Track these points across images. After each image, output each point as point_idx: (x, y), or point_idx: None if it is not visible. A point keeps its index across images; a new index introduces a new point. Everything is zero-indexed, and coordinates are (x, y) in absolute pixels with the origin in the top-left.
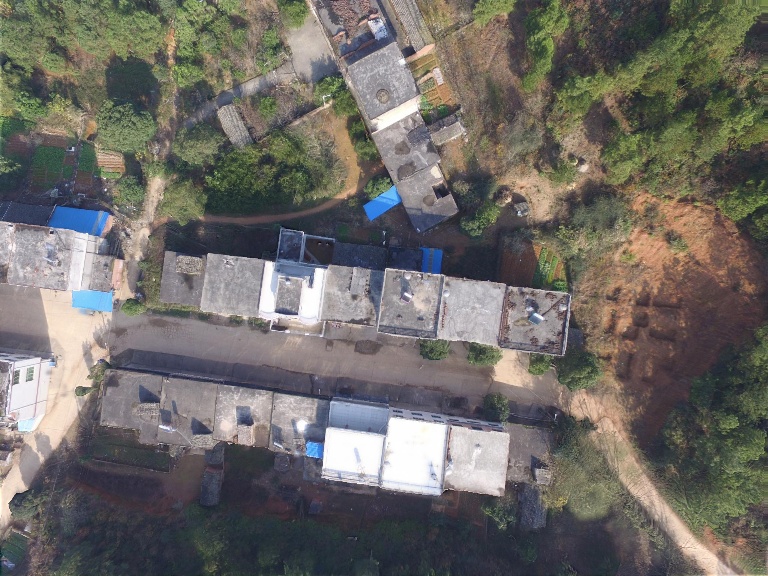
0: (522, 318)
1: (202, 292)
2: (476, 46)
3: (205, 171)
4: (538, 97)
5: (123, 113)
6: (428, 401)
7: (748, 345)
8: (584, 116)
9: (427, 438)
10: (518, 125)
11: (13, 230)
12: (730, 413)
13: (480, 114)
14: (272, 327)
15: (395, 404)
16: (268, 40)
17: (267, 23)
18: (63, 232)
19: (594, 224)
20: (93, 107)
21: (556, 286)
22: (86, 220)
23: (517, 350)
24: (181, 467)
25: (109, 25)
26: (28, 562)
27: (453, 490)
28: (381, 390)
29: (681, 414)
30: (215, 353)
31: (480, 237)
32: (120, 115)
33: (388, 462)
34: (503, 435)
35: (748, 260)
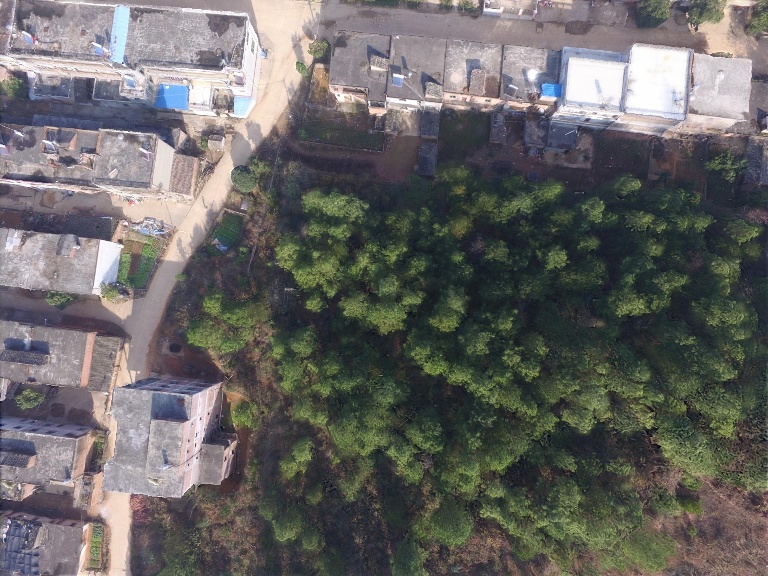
0: None
1: None
2: None
3: None
4: None
5: None
6: None
7: None
8: None
9: (669, 66)
10: None
11: None
12: None
13: None
14: (485, 6)
15: None
16: None
17: None
18: None
19: None
20: None
21: None
22: None
23: None
24: (393, 148)
25: None
26: (243, 240)
27: (669, 160)
28: None
29: None
30: None
31: None
32: None
33: (630, 90)
34: (745, 61)
35: None
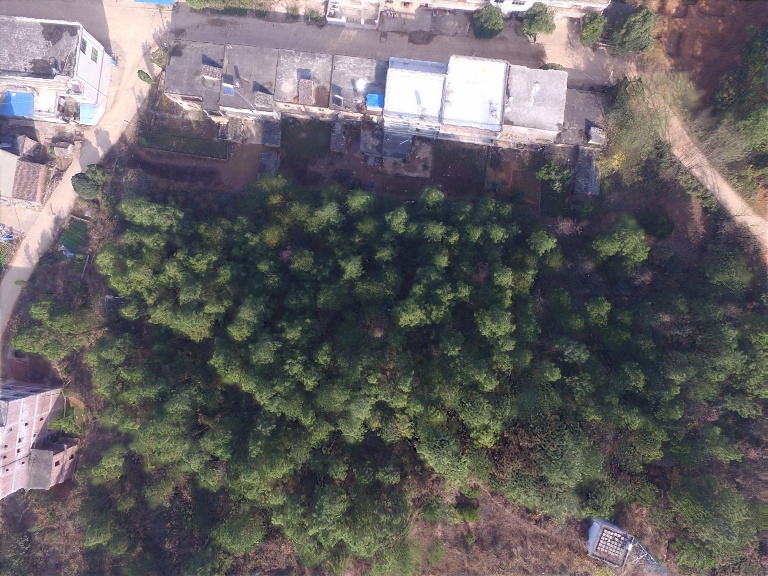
0: None
1: None
2: None
3: None
4: None
5: None
6: None
7: None
8: None
9: (486, 77)
10: None
11: None
12: None
13: None
14: (328, 16)
15: None
16: None
17: None
18: None
19: None
20: None
21: None
22: None
23: None
24: (238, 156)
25: None
26: None
27: (506, 169)
28: None
29: (733, 72)
30: None
31: None
32: None
33: (448, 101)
34: (561, 72)
35: None
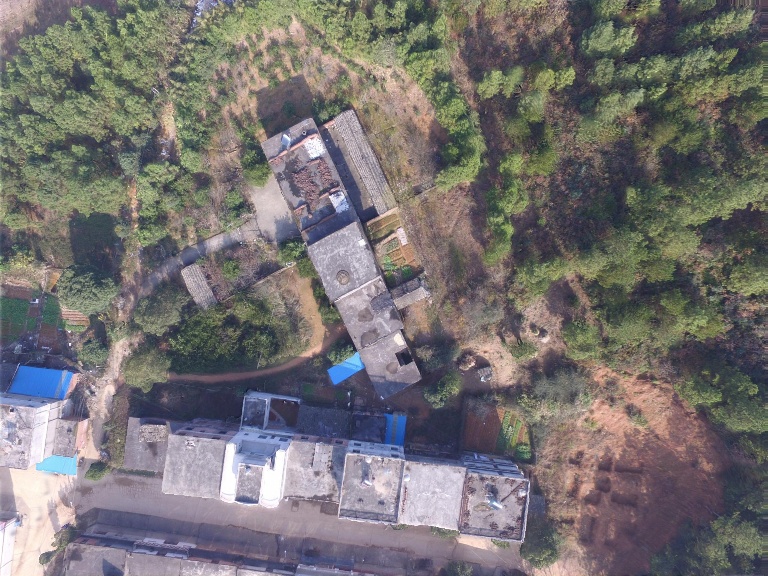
0: (482, 503)
1: (163, 474)
2: (439, 210)
3: (169, 332)
4: (500, 266)
5: (84, 284)
6: (393, 562)
7: (704, 533)
8: (545, 291)
9: None
10: (479, 302)
11: None
12: None
13: (443, 278)
14: None
15: (361, 566)
16: (231, 201)
17: (230, 184)
18: (23, 410)
19: (555, 396)
20: (57, 259)
21: (519, 450)
22: (49, 381)
23: None
24: None
25: (70, 190)
26: None
27: None
28: (347, 551)
29: None
30: (181, 513)
31: None
32: (81, 286)
33: None
34: None
35: (705, 441)
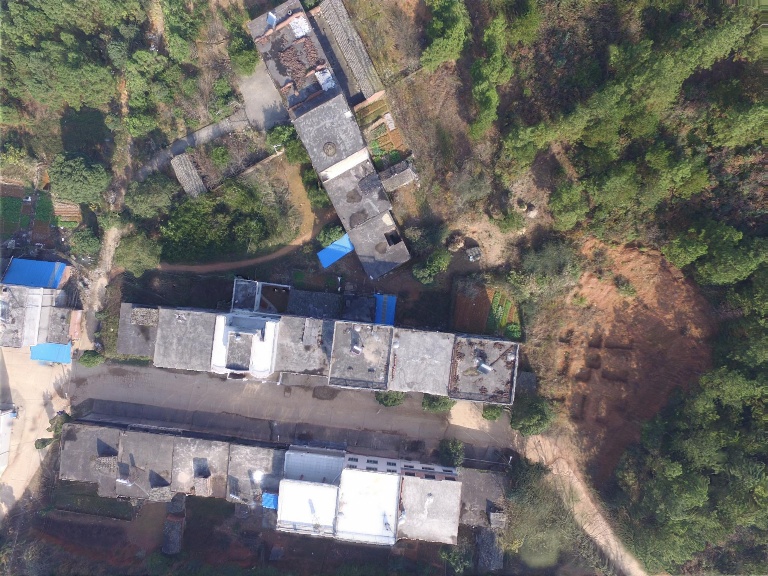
0: (471, 368)
1: (155, 347)
2: (426, 92)
3: (160, 221)
4: (487, 143)
5: (74, 168)
6: (386, 445)
7: (693, 391)
8: (531, 163)
9: (380, 488)
10: (465, 174)
11: None
12: (675, 460)
13: (431, 160)
14: (230, 375)
15: (353, 449)
16: (219, 89)
17: (218, 72)
18: (16, 289)
19: (544, 269)
20: (49, 156)
21: (509, 329)
22: (43, 272)
23: (467, 399)
24: (143, 515)
25: (59, 78)
26: None
27: None
28: (339, 435)
29: (632, 456)
30: (175, 401)
31: (434, 282)
32: (71, 170)
33: (342, 513)
34: (454, 484)
35: (693, 305)
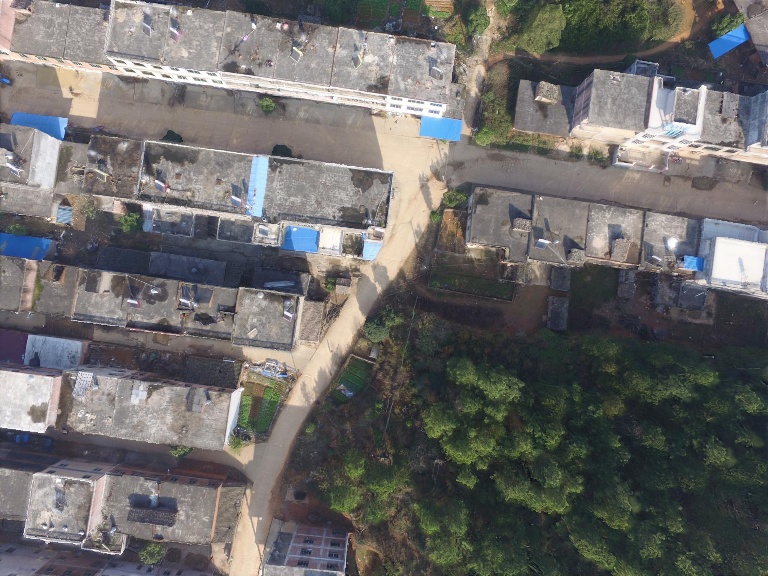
0: None
1: (590, 106)
2: None
3: None
4: None
5: None
6: None
7: None
8: None
9: None
10: None
11: (394, 42)
12: None
13: None
14: None
15: None
16: None
17: None
18: (444, 46)
19: None
20: None
21: None
22: None
23: None
24: (522, 297)
25: None
26: (371, 388)
27: None
28: None
29: None
30: (554, 187)
31: None
32: None
33: None
34: None
35: None
